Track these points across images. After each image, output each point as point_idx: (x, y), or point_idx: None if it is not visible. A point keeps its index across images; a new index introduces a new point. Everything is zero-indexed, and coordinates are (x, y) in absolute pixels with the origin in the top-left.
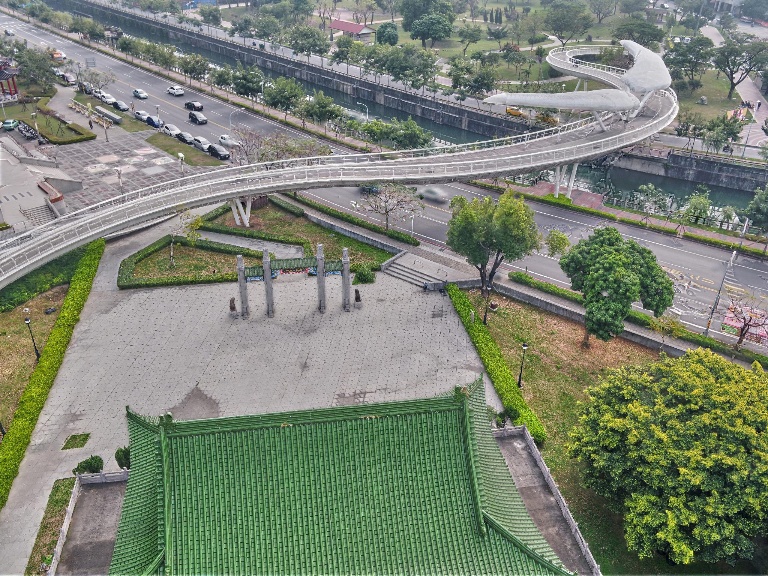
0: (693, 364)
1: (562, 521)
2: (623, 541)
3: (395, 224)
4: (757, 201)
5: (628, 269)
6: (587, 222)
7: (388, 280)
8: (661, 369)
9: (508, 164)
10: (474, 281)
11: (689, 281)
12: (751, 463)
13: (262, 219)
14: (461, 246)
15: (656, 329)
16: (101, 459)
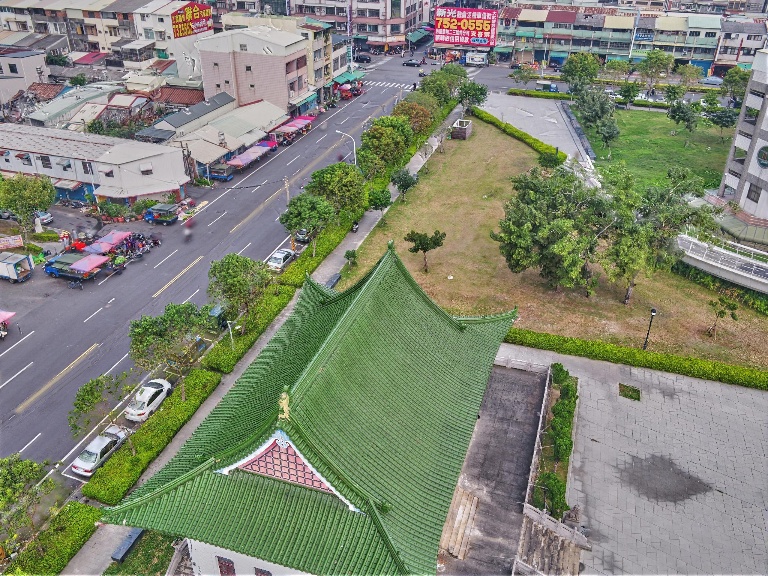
0: None
1: None
2: None
3: None
4: None
5: None
6: None
7: None
8: None
9: None
10: None
11: None
12: None
13: None
14: None
15: None
16: (561, 375)
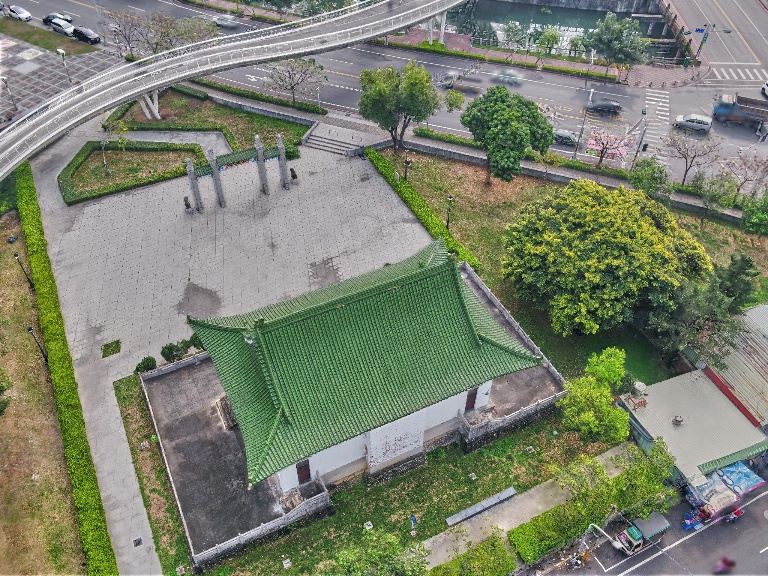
0: (582, 196)
1: (507, 324)
2: (546, 327)
3: (306, 99)
4: (599, 33)
5: (519, 121)
6: (462, 66)
7: (311, 153)
8: (560, 203)
9: (392, 24)
10: (386, 142)
11: (554, 112)
12: (629, 261)
13: (170, 109)
14: (375, 115)
15: (540, 162)
16: (153, 358)
